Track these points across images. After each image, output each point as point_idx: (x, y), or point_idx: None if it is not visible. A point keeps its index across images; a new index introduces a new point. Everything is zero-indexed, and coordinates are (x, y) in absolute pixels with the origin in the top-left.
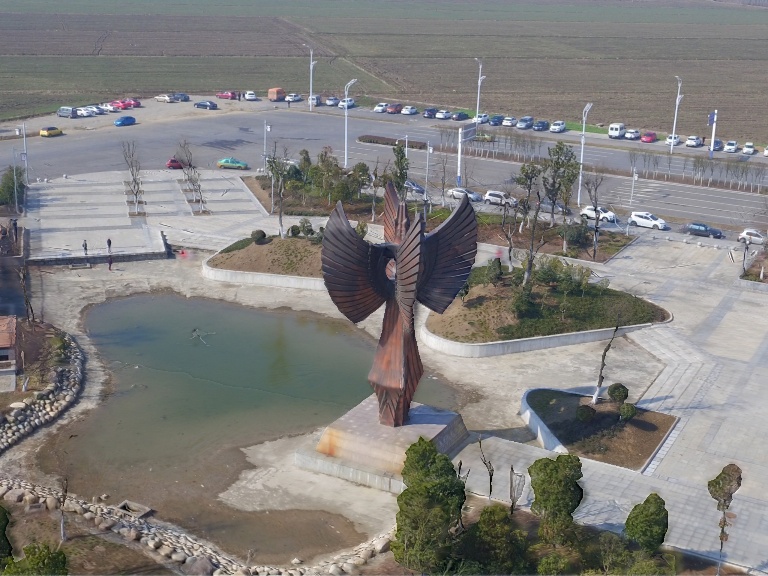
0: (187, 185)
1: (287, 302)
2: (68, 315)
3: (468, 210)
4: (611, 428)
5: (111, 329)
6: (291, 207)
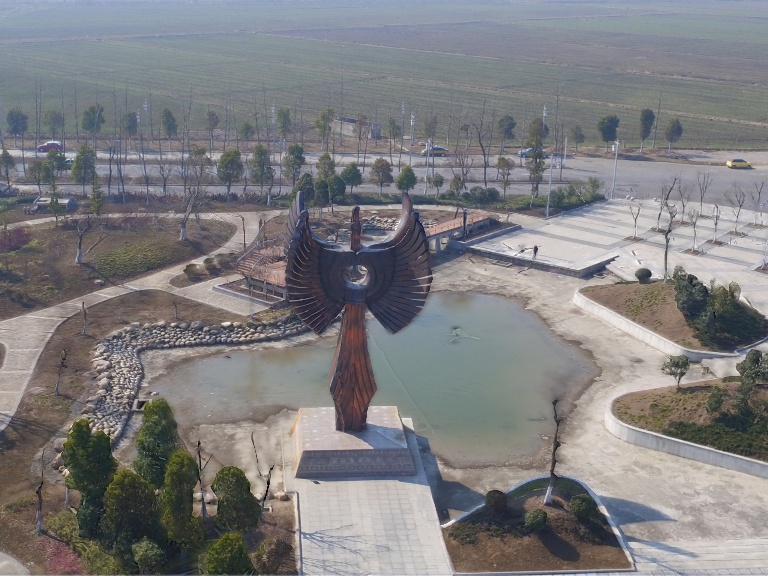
0: (735, 227)
1: (589, 339)
2: None
3: (417, 230)
4: (505, 527)
5: None
6: None
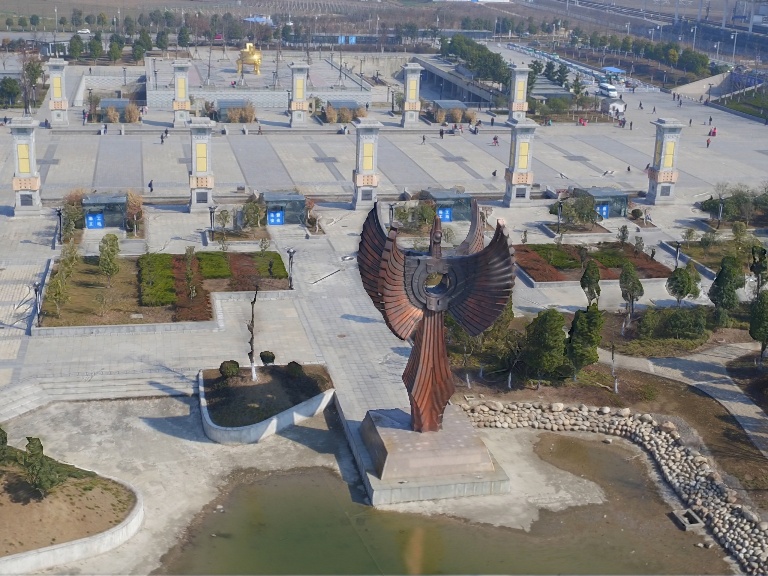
0: None
1: None
2: None
3: None
4: None
5: None
6: None
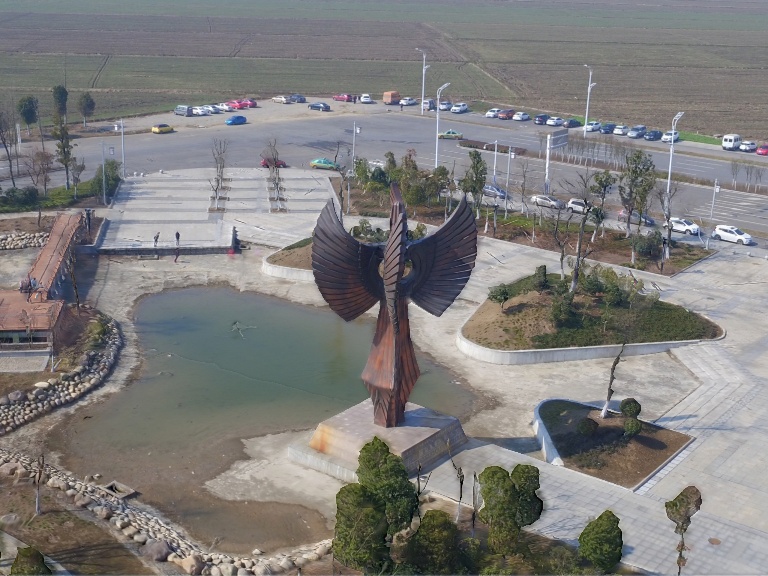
0: None
1: None
2: (122, 303)
3: (467, 213)
4: (613, 443)
5: (158, 318)
6: (367, 208)
